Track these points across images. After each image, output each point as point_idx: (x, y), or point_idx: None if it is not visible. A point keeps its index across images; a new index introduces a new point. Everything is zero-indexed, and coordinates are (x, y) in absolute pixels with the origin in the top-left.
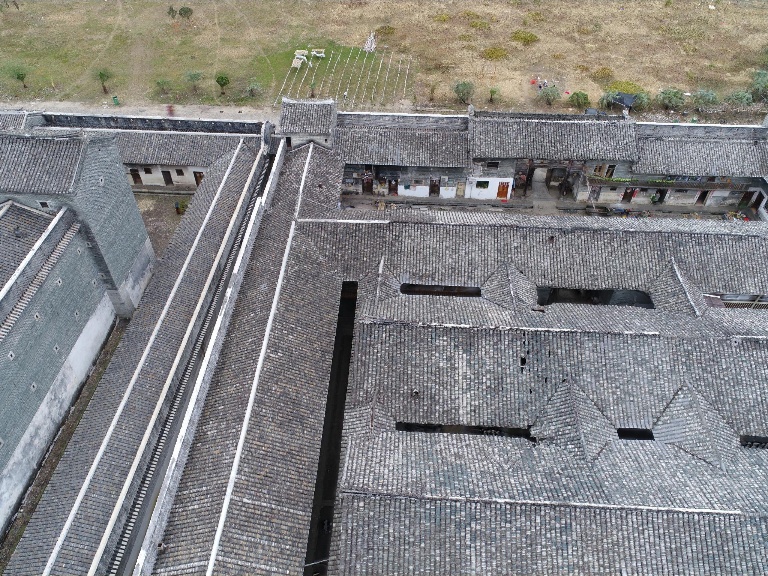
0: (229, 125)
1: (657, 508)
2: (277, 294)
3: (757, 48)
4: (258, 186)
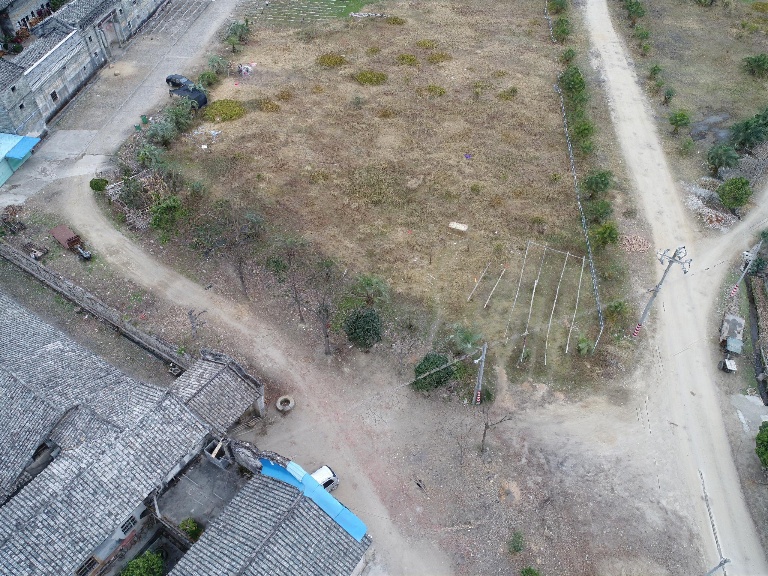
0: None
1: None
2: None
3: (309, 237)
4: None
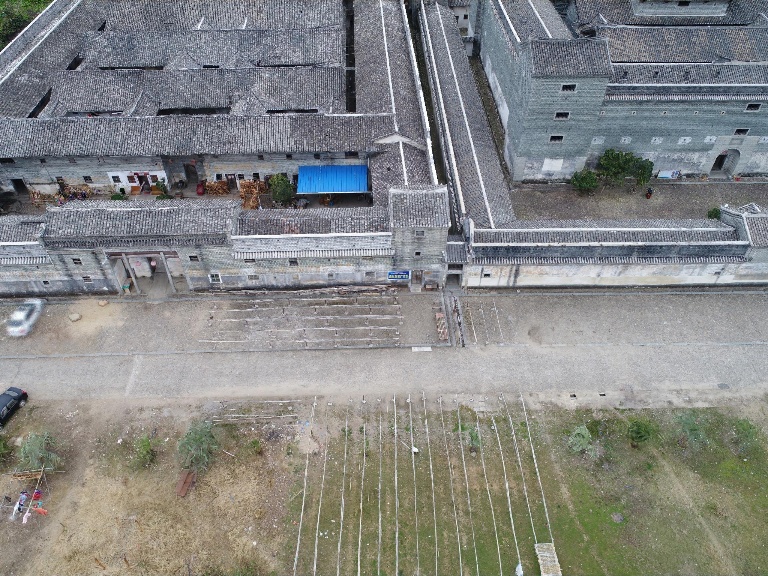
0: (522, 249)
1: (224, 29)
2: (390, 81)
3: None
4: (454, 201)
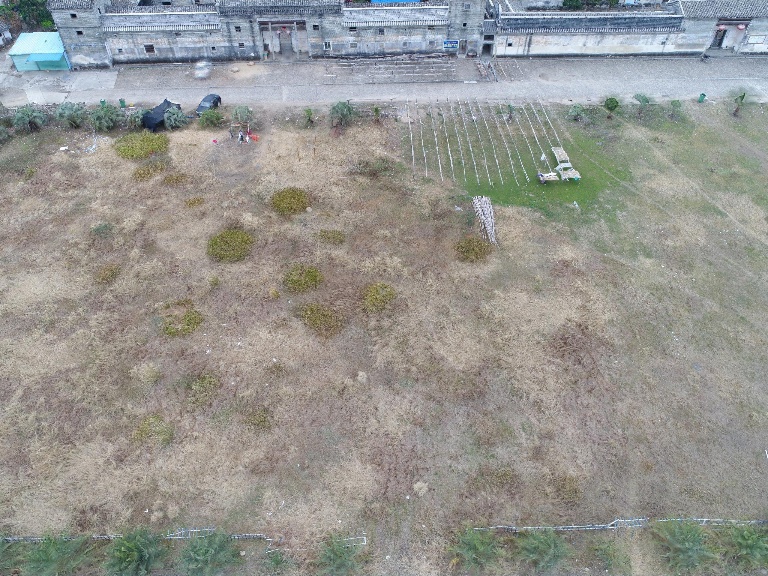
0: (534, 21)
1: None
2: None
3: None
4: None
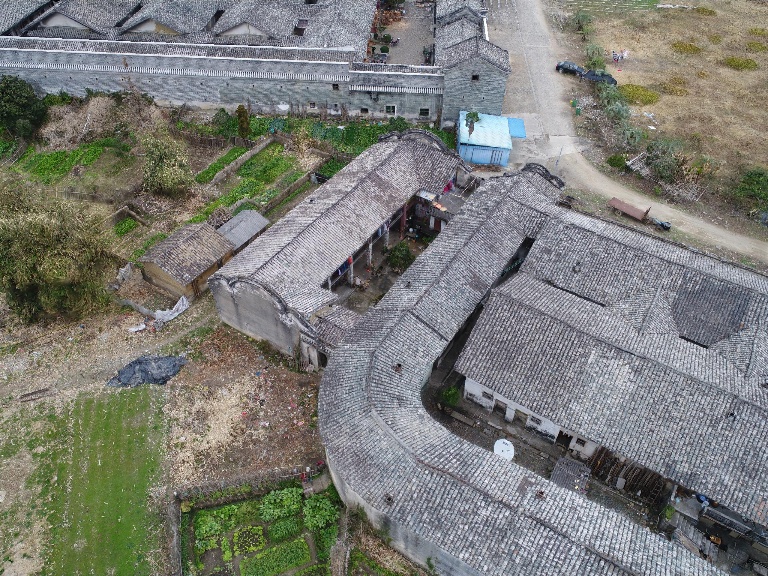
0: None
1: None
2: None
3: None
4: None
